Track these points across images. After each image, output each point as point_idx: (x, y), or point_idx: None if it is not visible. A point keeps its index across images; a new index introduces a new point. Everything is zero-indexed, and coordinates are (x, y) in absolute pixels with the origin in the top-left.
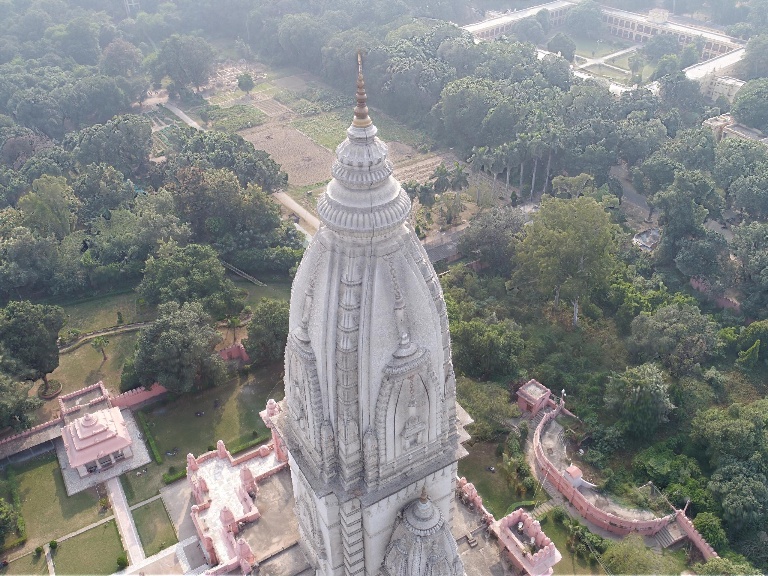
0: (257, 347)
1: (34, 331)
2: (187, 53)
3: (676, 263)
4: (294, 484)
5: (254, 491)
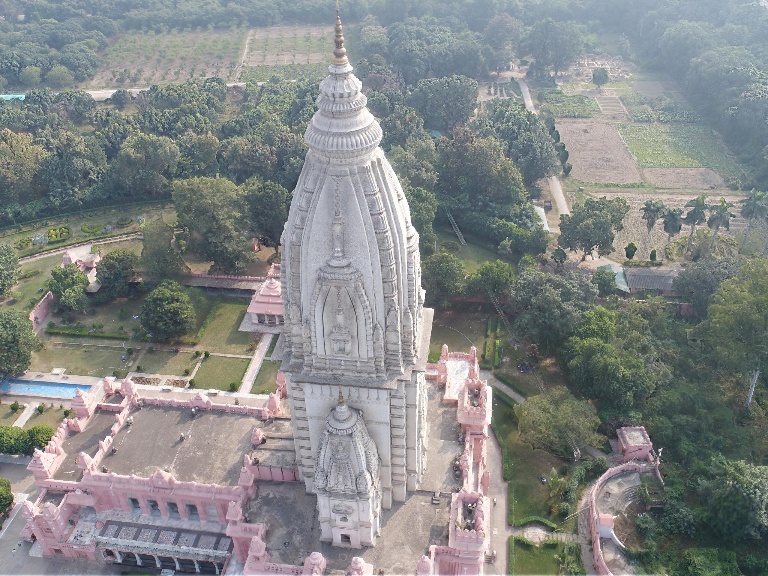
0: None
1: (276, 208)
2: (554, 36)
3: None
4: None
5: None
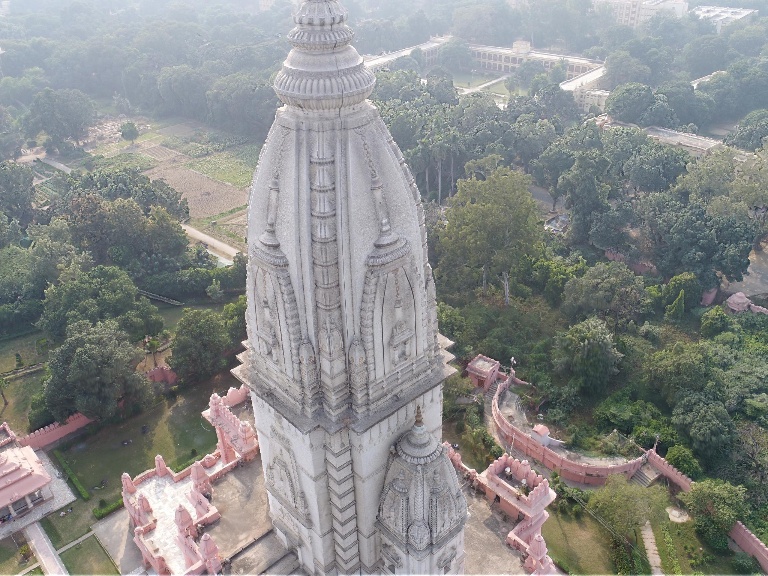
0: (184, 361)
1: None
2: (63, 105)
3: (591, 236)
4: (263, 452)
5: (209, 492)
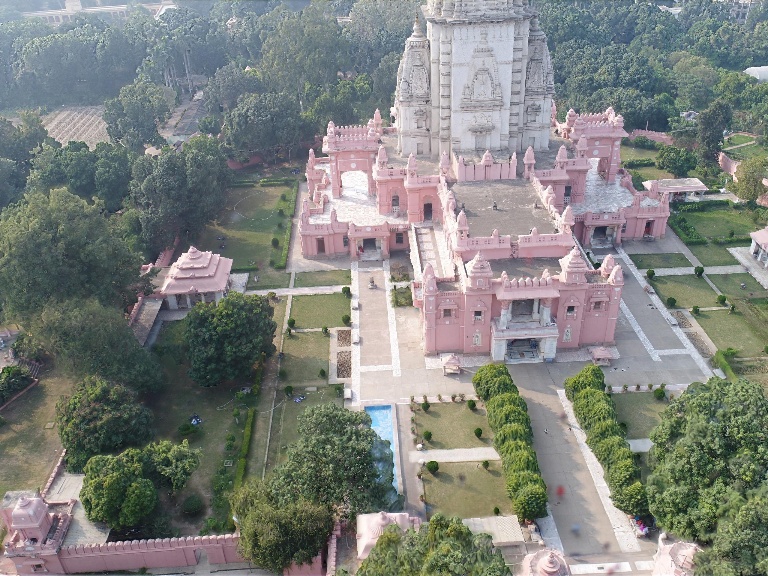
0: None
1: None
2: None
3: None
4: (458, 83)
5: None
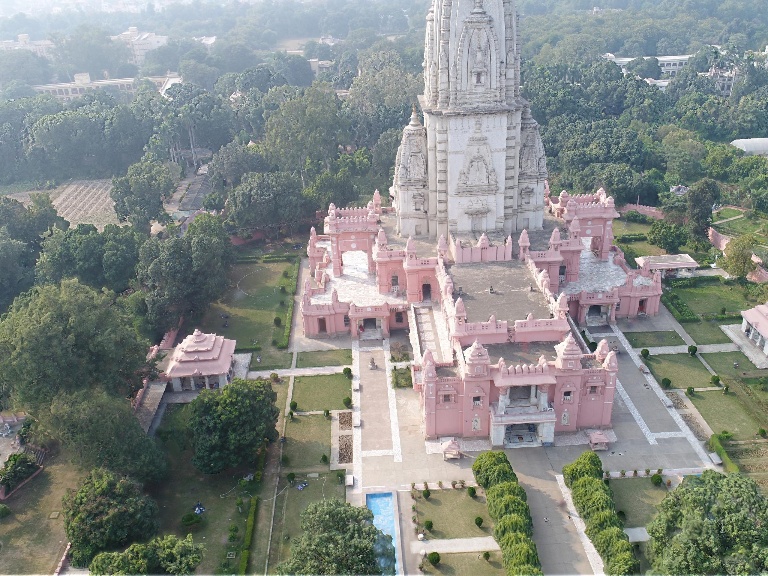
0: None
1: None
2: None
3: None
4: (454, 169)
5: None
